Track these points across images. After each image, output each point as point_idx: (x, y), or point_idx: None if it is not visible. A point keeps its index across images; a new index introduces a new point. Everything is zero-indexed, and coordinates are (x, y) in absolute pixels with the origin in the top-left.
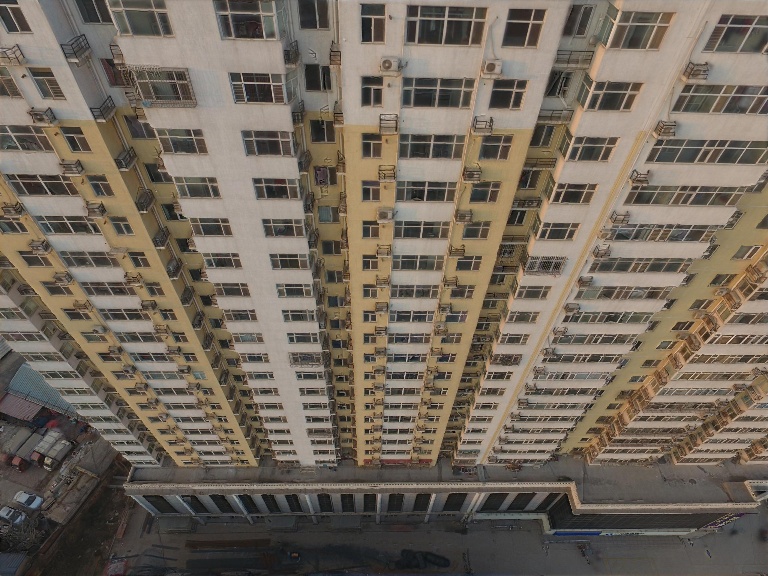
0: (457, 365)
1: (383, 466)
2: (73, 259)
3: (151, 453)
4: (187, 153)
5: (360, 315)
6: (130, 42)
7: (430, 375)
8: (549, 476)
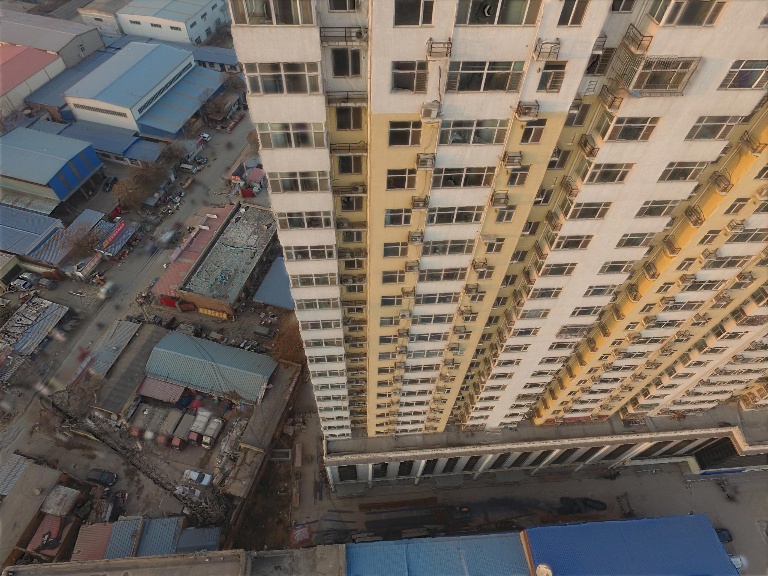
0: (705, 328)
1: (561, 424)
2: (431, 248)
3: (350, 426)
4: (627, 140)
5: (658, 287)
6: (668, 32)
7: (680, 339)
8: (711, 423)
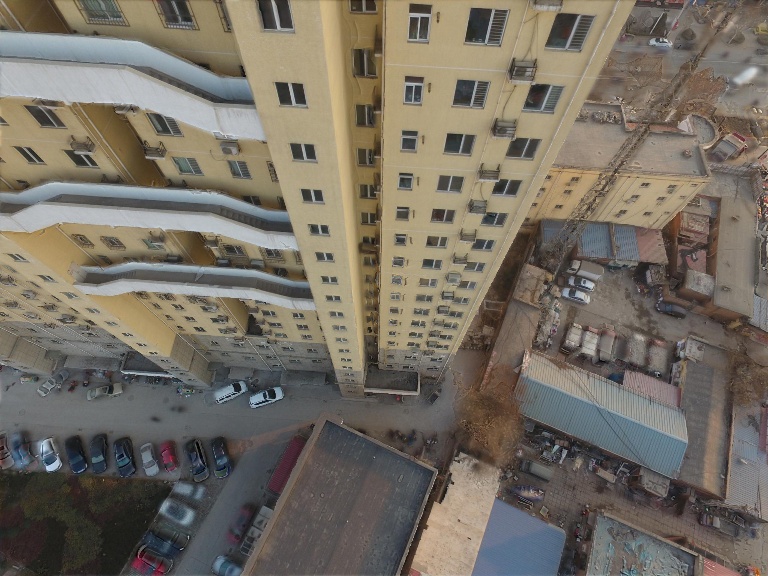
0: None
1: None
2: None
3: None
4: None
5: None
6: None
7: None
8: None
